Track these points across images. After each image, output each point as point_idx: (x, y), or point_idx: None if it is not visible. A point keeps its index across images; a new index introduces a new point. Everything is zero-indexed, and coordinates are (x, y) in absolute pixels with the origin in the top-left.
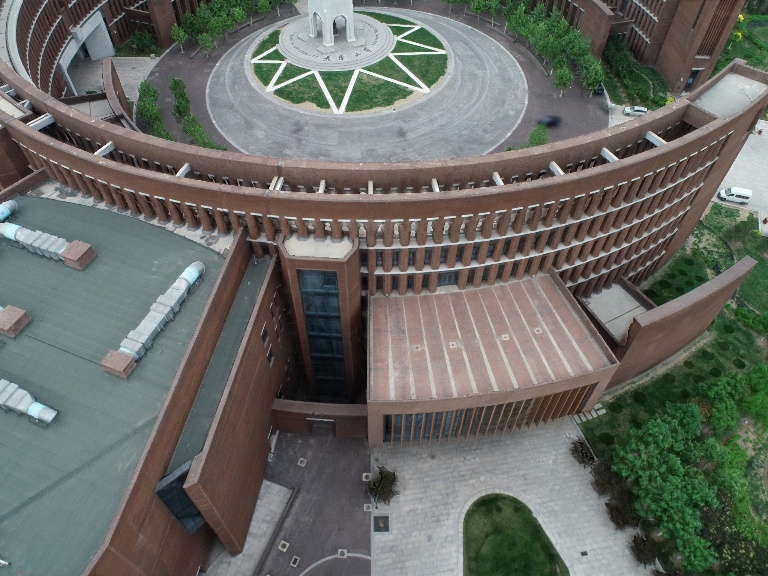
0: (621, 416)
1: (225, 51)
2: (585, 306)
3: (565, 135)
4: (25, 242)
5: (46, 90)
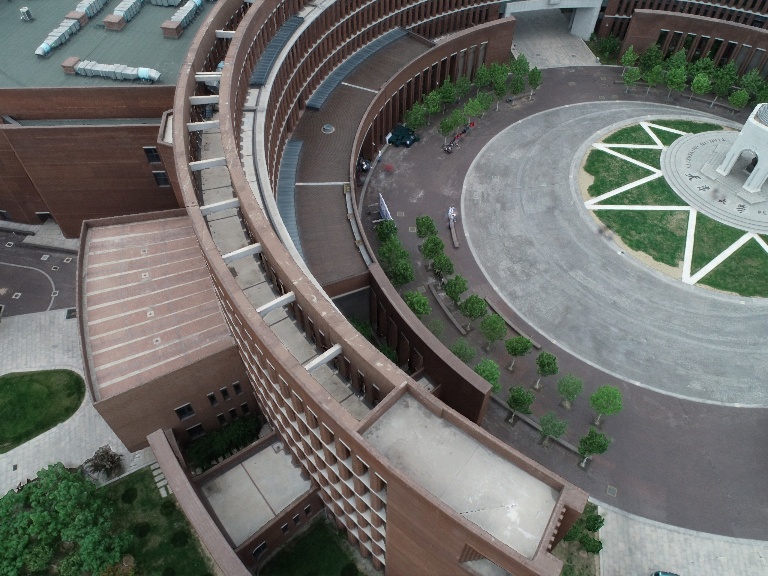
0: (156, 513)
1: (646, 100)
2: (260, 438)
3: (677, 463)
4: (181, 7)
5: (453, 5)
